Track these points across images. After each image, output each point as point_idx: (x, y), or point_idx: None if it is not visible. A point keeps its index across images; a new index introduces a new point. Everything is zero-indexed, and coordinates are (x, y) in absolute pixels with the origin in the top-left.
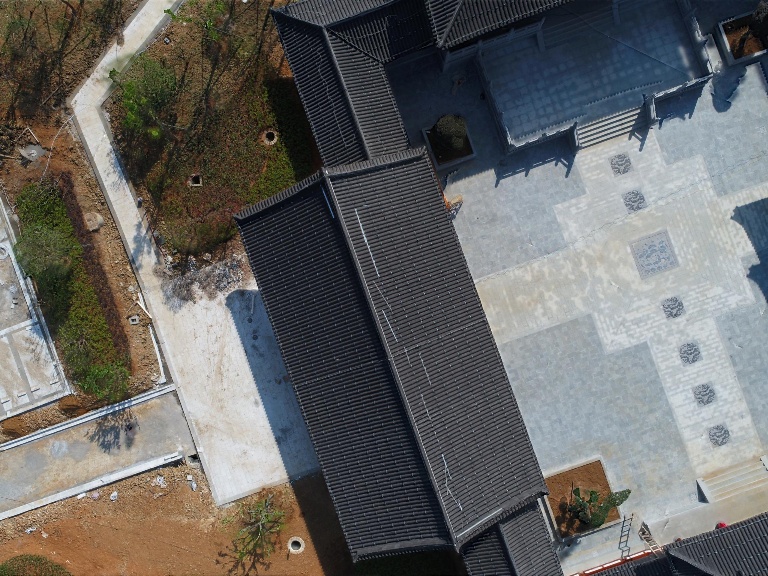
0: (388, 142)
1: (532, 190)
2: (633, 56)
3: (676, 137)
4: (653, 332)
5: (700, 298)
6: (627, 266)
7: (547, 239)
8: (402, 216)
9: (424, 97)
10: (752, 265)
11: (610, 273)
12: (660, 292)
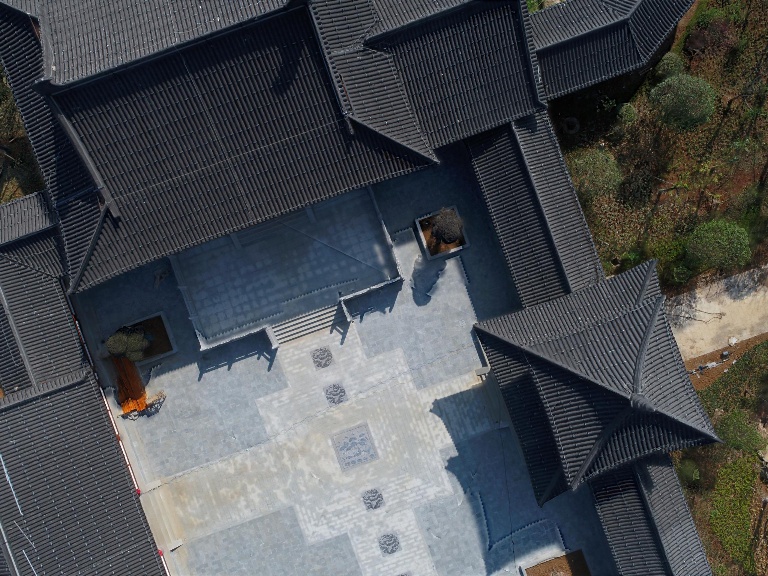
0: (59, 360)
1: (235, 384)
2: (329, 254)
3: (377, 331)
4: (353, 523)
5: (399, 490)
6: (328, 459)
7: (249, 432)
8: (58, 445)
9: (127, 291)
10: (450, 457)
11: (311, 466)
12: (360, 484)
